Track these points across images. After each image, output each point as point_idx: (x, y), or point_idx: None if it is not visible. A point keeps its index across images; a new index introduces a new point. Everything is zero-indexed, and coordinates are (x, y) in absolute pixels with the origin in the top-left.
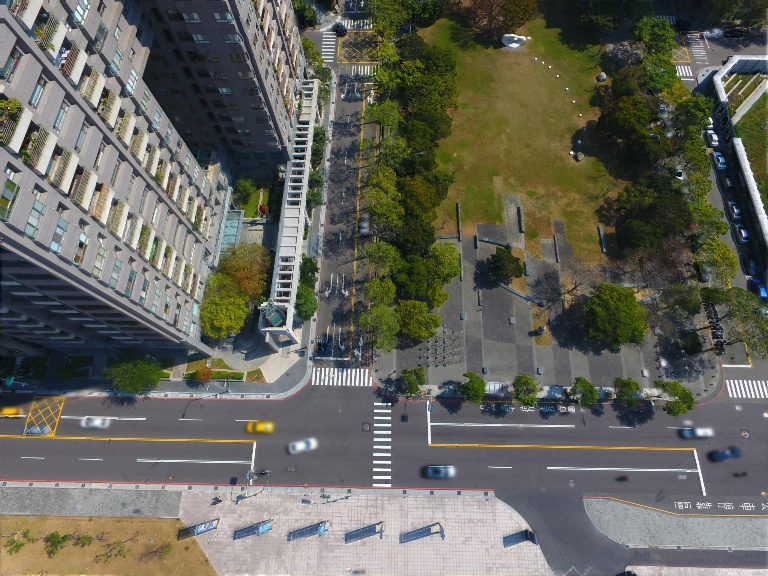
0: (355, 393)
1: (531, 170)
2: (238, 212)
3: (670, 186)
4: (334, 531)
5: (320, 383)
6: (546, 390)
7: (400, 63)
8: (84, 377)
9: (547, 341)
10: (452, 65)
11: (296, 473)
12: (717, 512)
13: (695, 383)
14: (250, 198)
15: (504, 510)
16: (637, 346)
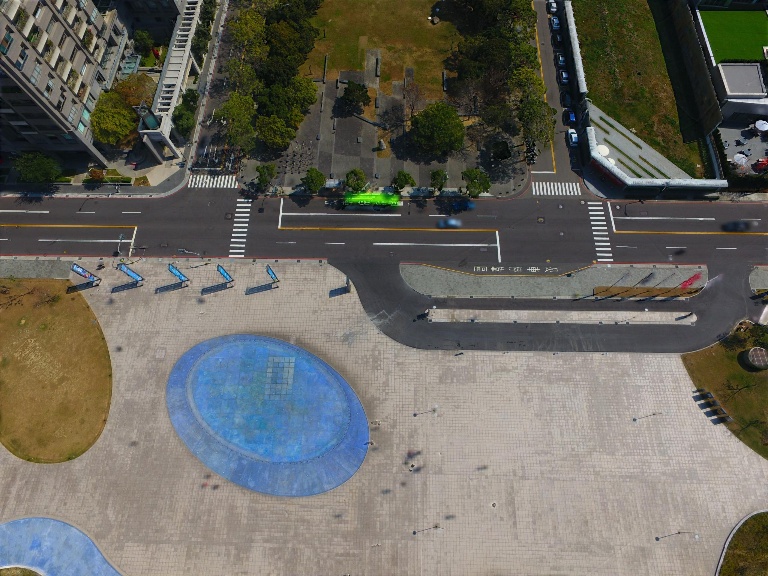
0: (222, 192)
1: (393, 31)
2: (136, 57)
3: (500, 34)
4: (193, 287)
5: (195, 186)
6: (381, 190)
7: None
8: (1, 182)
9: (387, 155)
10: None
11: (167, 248)
12: (508, 273)
13: (506, 184)
14: (151, 53)
15: (333, 272)
16: (462, 158)
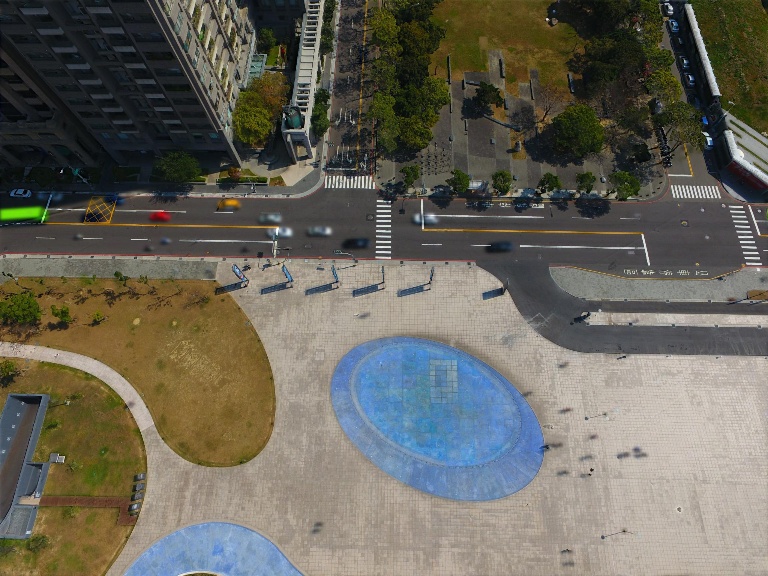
0: (361, 193)
1: (512, 32)
2: (261, 56)
3: (628, 36)
4: (344, 289)
5: (331, 186)
6: (520, 192)
7: None
8: (133, 181)
9: (522, 156)
10: None
11: (312, 249)
12: (659, 276)
13: (645, 187)
14: (271, 51)
15: (484, 275)
16: (598, 160)
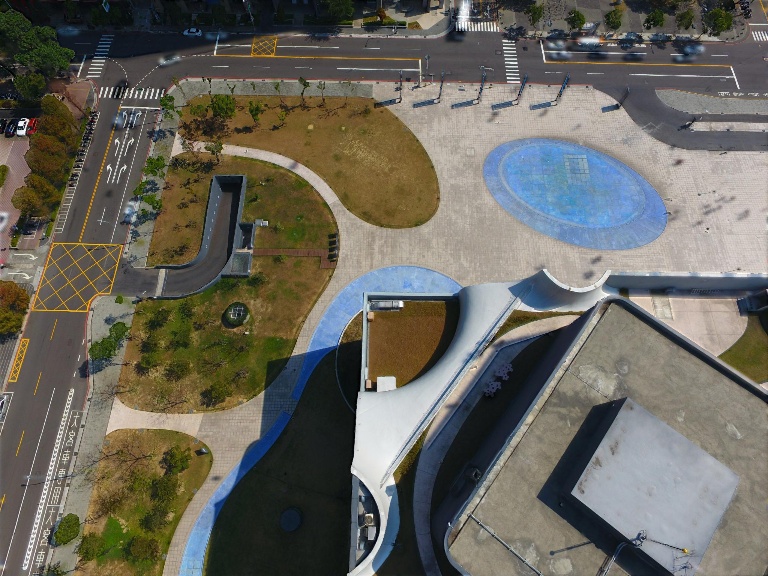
0: (488, 35)
1: None
2: None
3: None
4: (483, 104)
5: (462, 30)
6: (624, 35)
7: None
8: (289, 25)
9: (623, 8)
10: None
11: (452, 75)
12: (748, 97)
13: (730, 33)
14: None
15: (601, 95)
16: None
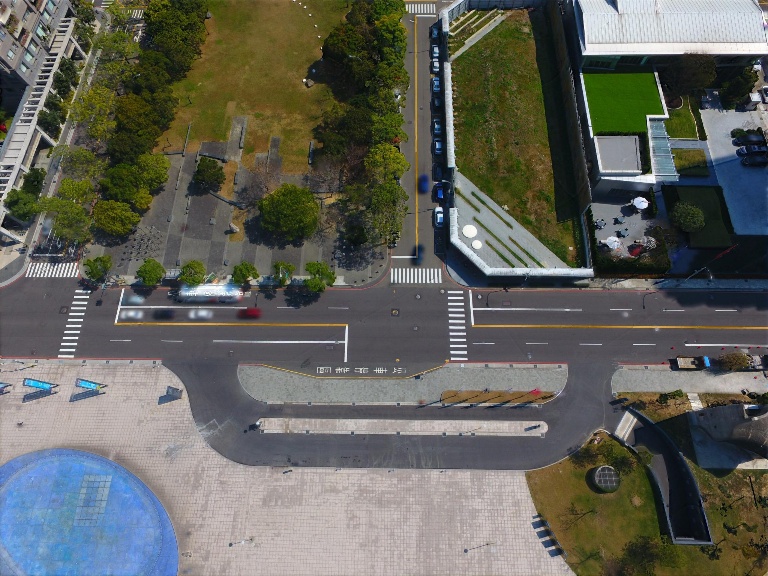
0: (61, 283)
1: (264, 96)
2: None
3: (368, 103)
4: (15, 393)
5: (33, 275)
6: (229, 278)
7: (149, 2)
8: None
9: (240, 238)
10: (197, 3)
11: None
12: (352, 375)
13: (363, 271)
14: (6, 123)
15: (166, 375)
16: (319, 241)
